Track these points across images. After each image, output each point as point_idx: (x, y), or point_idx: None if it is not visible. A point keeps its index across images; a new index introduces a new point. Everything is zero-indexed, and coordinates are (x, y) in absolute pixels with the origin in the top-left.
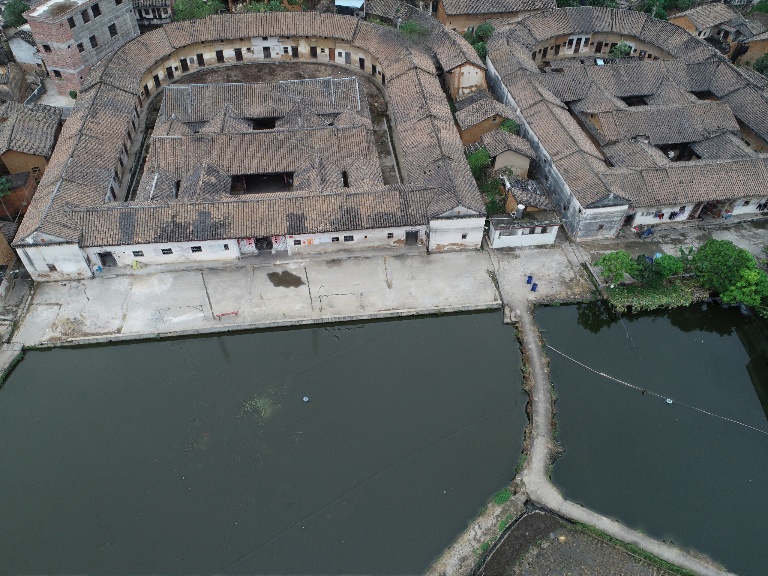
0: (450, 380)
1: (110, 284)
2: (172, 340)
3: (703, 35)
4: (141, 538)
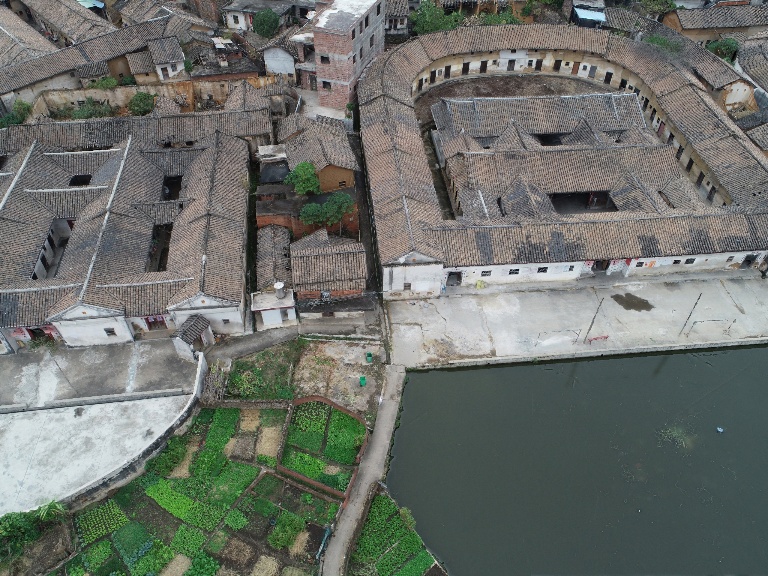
0: None
1: (459, 304)
2: (544, 364)
3: None
4: (630, 574)
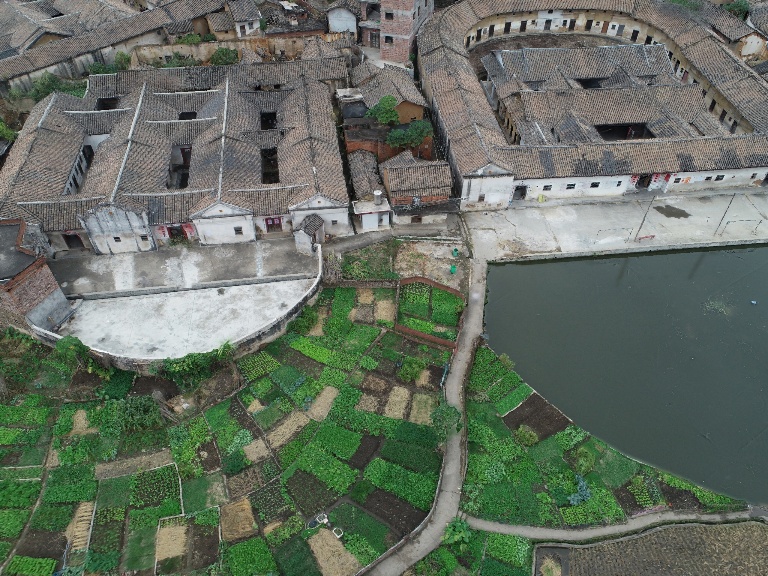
0: None
1: (524, 214)
2: (601, 259)
3: None
4: (690, 400)
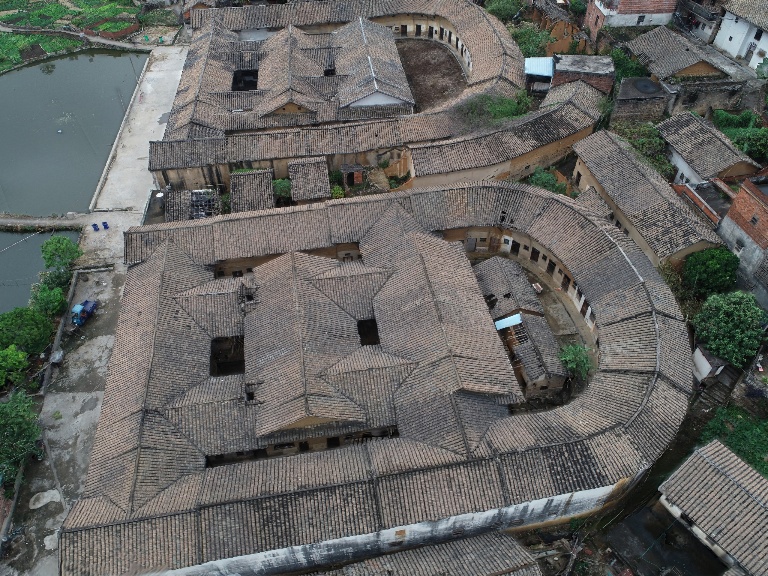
0: (43, 189)
1: None
2: None
3: (707, 537)
4: None
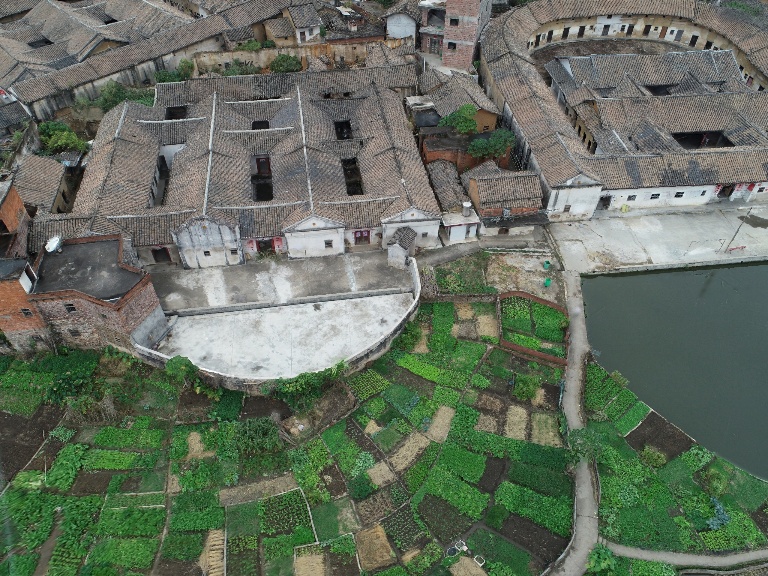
0: None
1: (609, 224)
2: (692, 270)
3: None
4: None
